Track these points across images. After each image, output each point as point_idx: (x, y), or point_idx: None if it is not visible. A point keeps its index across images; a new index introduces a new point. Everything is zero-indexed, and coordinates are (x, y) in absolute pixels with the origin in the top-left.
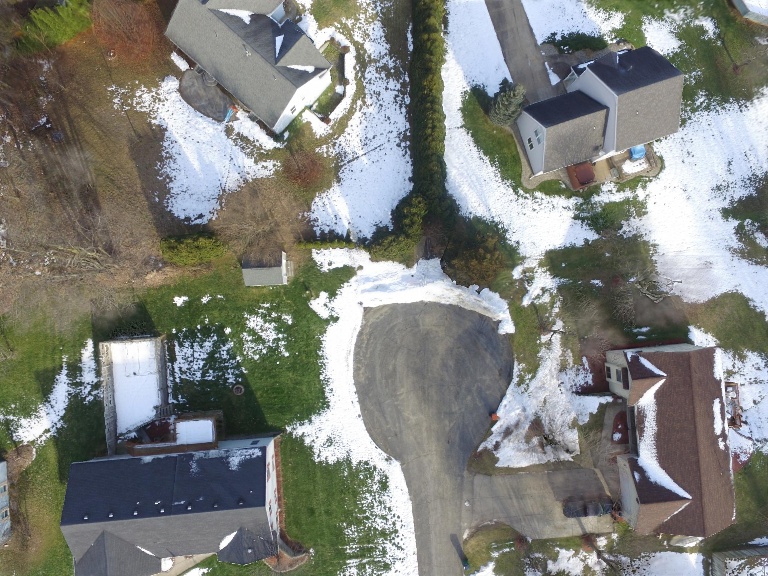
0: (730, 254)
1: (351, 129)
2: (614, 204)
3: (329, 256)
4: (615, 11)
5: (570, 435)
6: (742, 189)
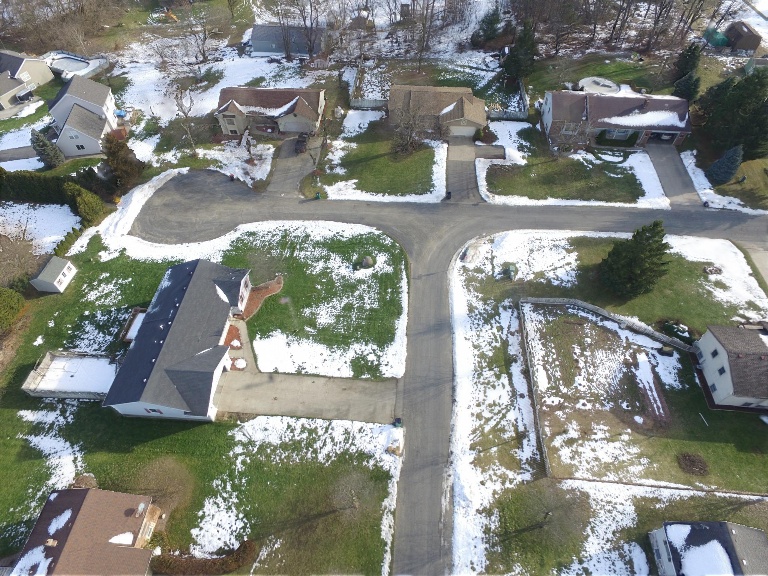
0: (202, 93)
1: (3, 232)
2: (145, 127)
3: (77, 247)
4: (41, 118)
5: (260, 147)
6: (172, 88)
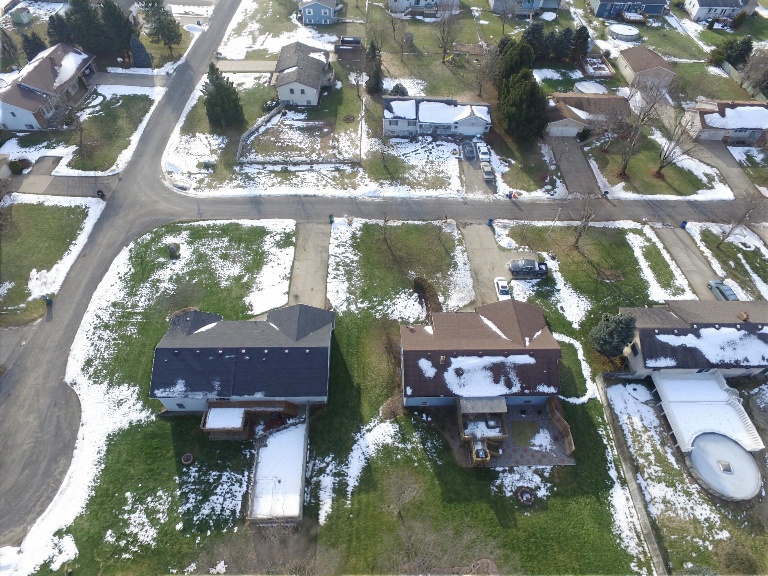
0: None
1: None
2: None
3: None
4: None
5: None
6: None
